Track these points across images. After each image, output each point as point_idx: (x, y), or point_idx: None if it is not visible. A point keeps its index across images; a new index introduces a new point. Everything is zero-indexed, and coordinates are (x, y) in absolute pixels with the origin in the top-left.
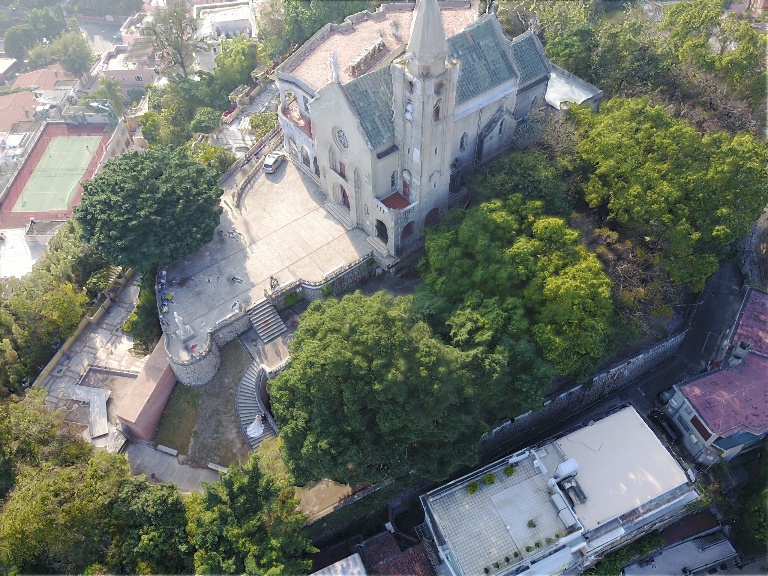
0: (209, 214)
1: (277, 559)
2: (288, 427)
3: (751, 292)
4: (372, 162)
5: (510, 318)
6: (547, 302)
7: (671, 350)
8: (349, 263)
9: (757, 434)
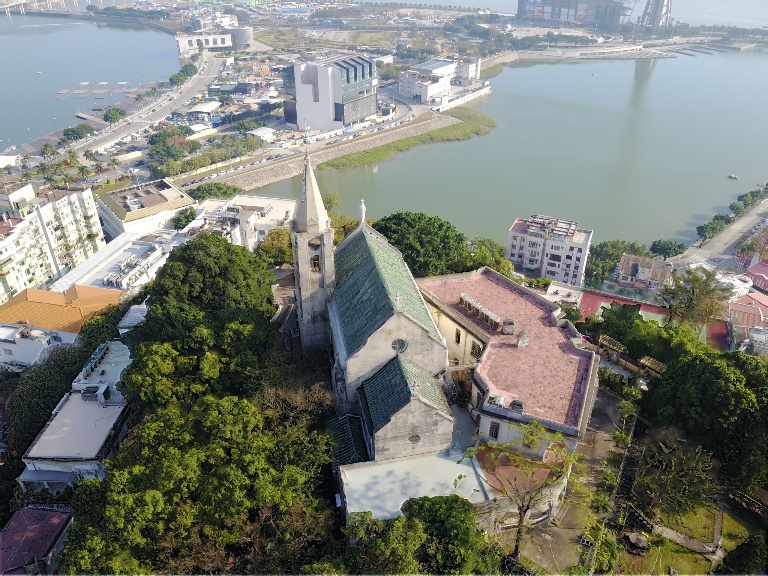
0: None
1: None
2: None
3: None
4: None
5: None
6: None
7: None
8: None
9: None
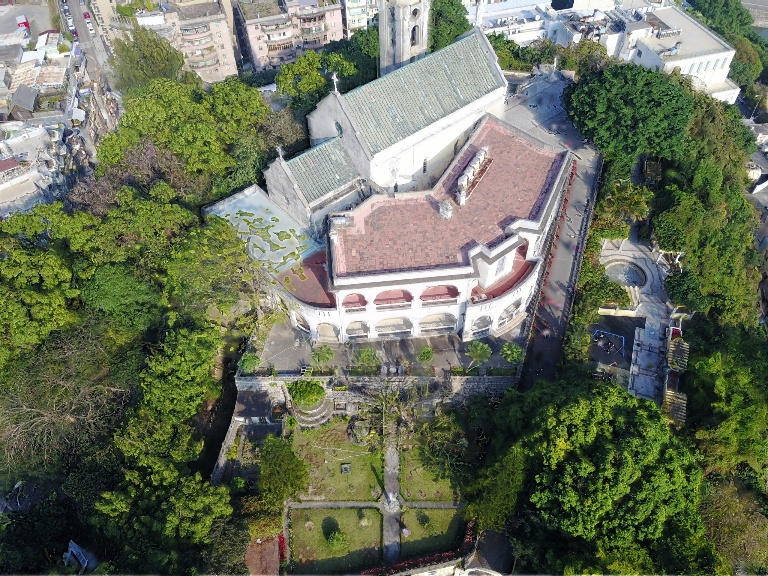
0: None
1: None
2: None
3: None
4: None
5: None
6: None
7: None
8: None
9: None
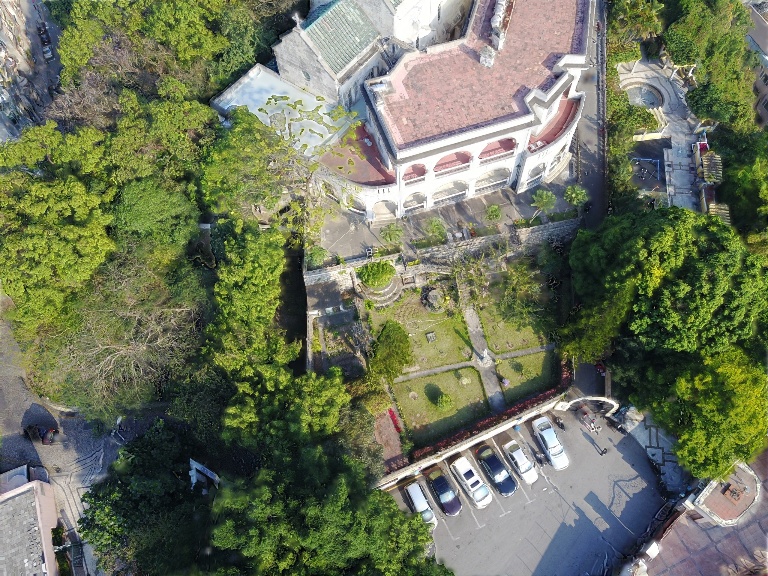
0: None
1: None
2: None
3: None
4: None
5: None
6: None
7: None
8: None
9: None
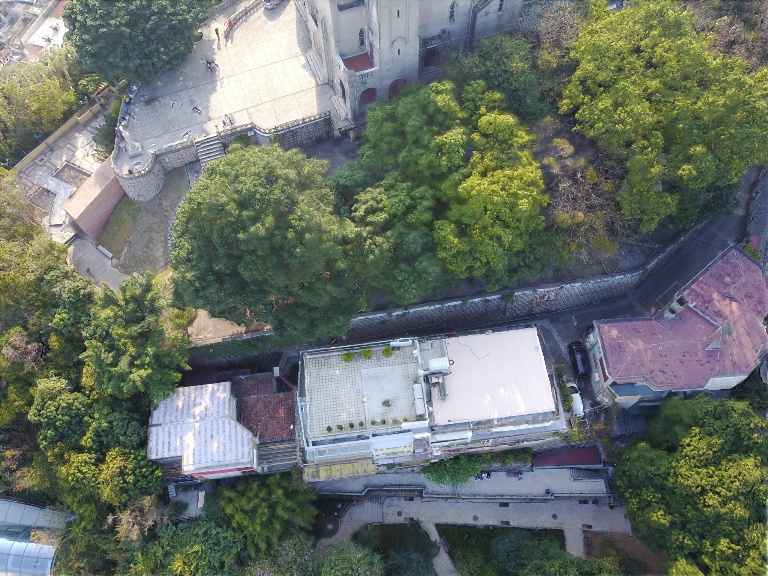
0: (182, 37)
1: (150, 364)
2: (171, 253)
3: (731, 250)
4: (332, 13)
5: (415, 207)
6: (467, 201)
7: (620, 288)
8: (304, 118)
9: (655, 390)
